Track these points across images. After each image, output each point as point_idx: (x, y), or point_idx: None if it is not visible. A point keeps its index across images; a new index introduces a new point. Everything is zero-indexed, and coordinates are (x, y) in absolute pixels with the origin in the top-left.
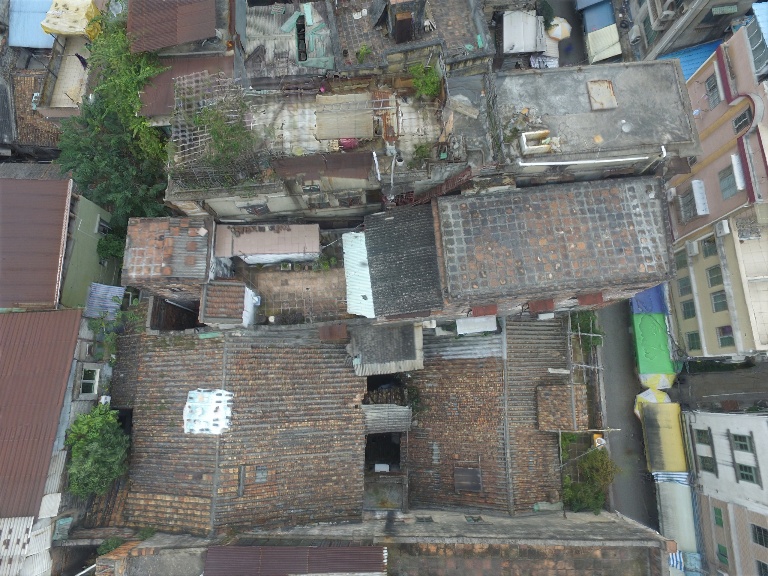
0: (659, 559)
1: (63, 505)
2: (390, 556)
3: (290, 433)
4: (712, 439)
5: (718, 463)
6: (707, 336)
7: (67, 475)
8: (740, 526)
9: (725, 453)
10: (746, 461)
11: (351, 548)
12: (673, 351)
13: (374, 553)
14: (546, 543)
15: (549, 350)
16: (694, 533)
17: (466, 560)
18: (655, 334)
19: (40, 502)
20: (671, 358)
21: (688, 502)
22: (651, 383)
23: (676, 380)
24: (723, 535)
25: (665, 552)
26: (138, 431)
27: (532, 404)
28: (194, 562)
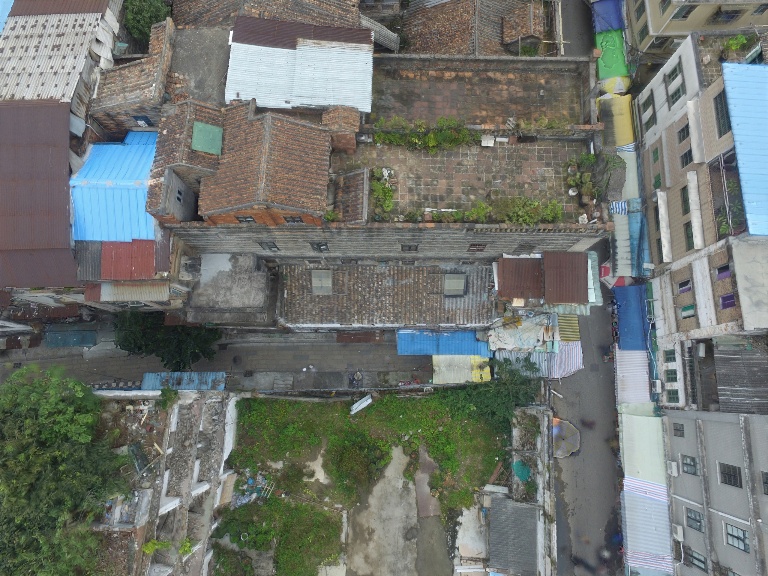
0: (588, 70)
1: (120, 36)
2: (377, 80)
3: (300, 3)
4: (653, 96)
5: (657, 111)
6: (653, 18)
7: (123, 18)
8: (670, 141)
9: (662, 97)
10: (676, 85)
11: (346, 28)
12: (627, 53)
13: (364, 32)
14: (500, 58)
15: (516, 1)
16: (637, 185)
17: (437, 83)
18: (614, 54)
19: (106, 8)
20: (626, 62)
21: (634, 164)
22: (608, 87)
23: (630, 86)
24: (658, 165)
25: (593, 64)
26: (178, 12)
27: (499, 30)
28: (226, 34)
